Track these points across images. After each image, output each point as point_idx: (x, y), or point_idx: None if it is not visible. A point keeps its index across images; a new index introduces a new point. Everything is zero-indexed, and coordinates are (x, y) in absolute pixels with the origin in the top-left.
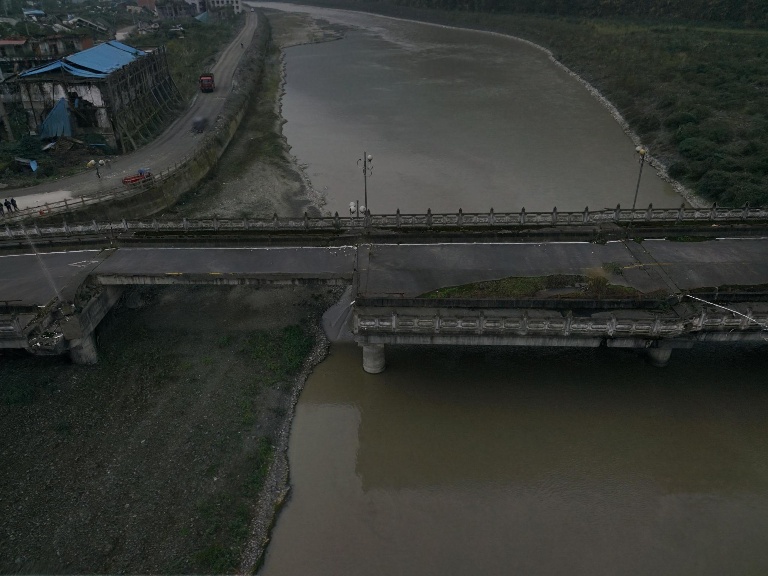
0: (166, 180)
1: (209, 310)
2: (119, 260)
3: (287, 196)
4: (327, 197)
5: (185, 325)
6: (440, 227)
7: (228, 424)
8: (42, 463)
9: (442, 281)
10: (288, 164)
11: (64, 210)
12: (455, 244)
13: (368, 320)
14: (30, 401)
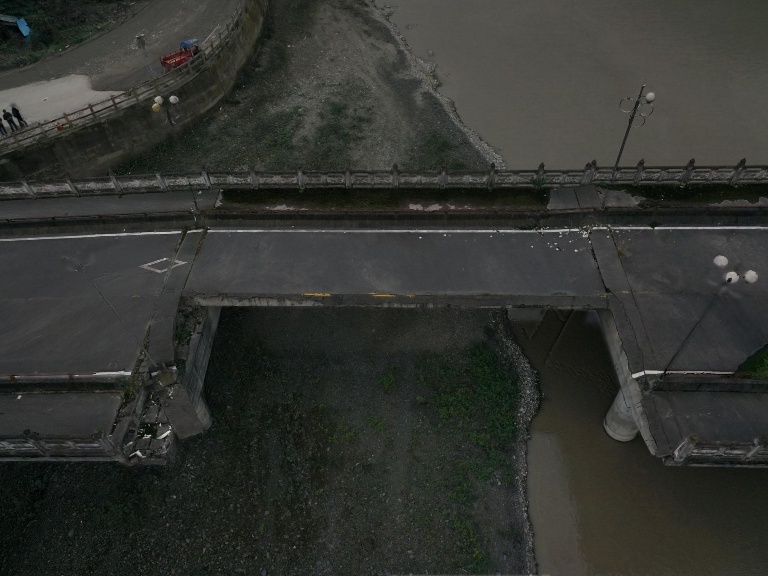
0: (219, 54)
1: (344, 309)
2: (218, 259)
3: (385, 72)
4: (438, 71)
5: (320, 343)
6: (701, 185)
7: (450, 570)
8: None
9: (766, 324)
10: (367, 8)
11: (91, 121)
12: (745, 229)
13: (708, 448)
14: (136, 521)
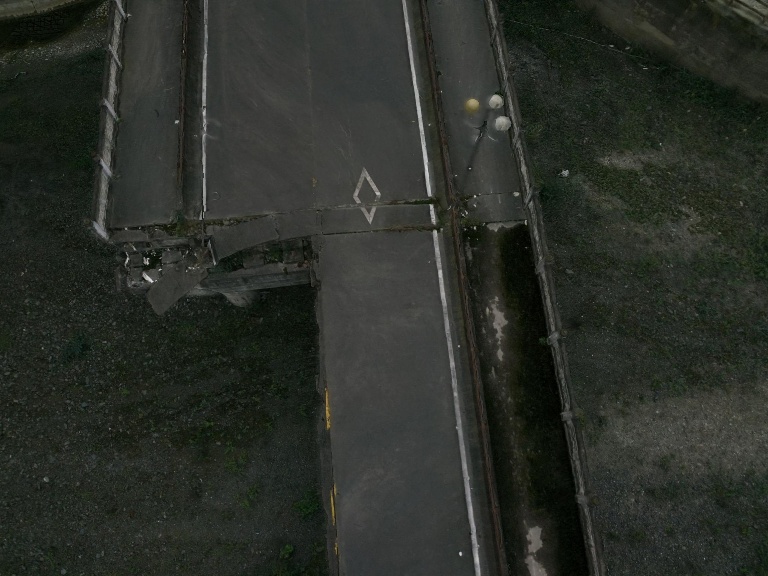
0: None
1: None
2: (380, 261)
3: None
4: None
5: None
6: None
7: None
8: (8, 361)
9: None
10: None
11: None
12: None
13: None
14: None
